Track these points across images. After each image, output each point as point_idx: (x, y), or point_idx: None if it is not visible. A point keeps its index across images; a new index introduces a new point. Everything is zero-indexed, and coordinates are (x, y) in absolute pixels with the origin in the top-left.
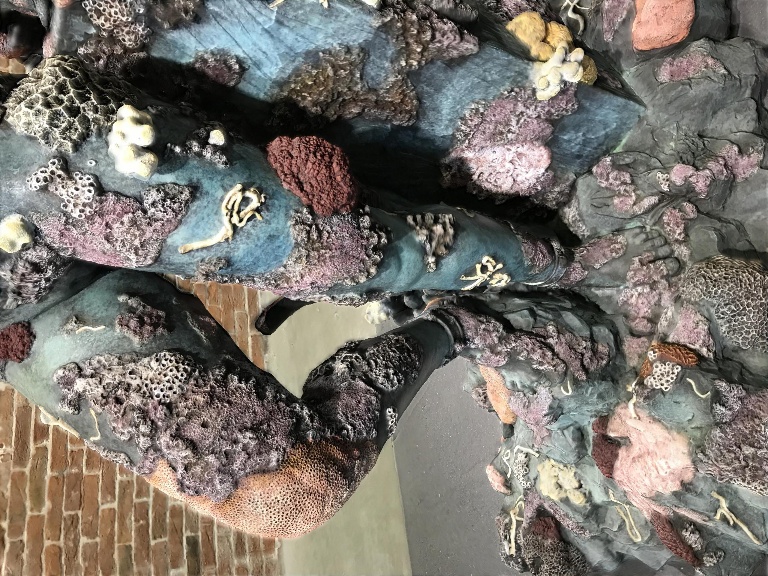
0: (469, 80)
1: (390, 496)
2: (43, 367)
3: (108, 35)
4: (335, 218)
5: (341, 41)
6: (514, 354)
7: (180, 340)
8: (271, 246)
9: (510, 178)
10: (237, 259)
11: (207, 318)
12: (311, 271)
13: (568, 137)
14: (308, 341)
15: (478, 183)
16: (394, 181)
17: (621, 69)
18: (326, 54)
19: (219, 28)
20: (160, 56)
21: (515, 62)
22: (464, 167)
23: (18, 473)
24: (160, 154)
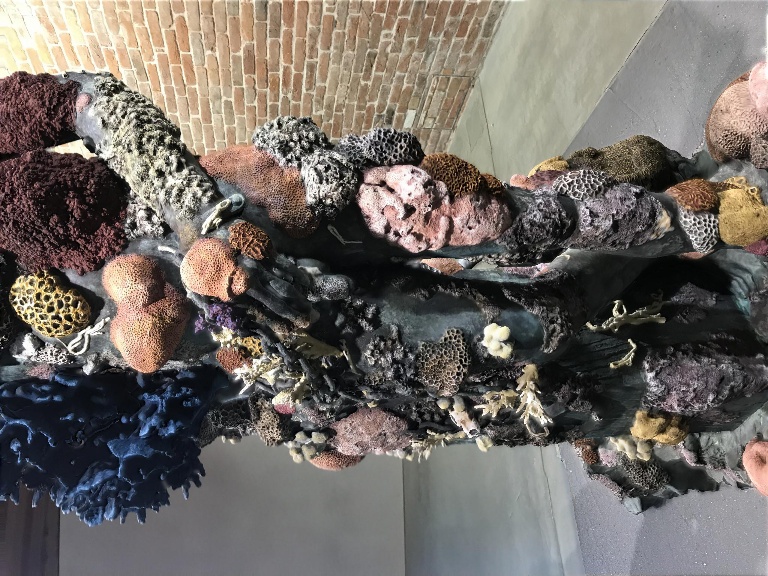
0: None
1: (613, 48)
2: None
3: None
4: None
5: None
6: None
7: None
8: None
9: None
10: None
11: None
12: None
13: None
14: None
15: None
16: None
17: (763, 409)
18: None
19: None
20: None
21: None
22: None
23: None
24: None
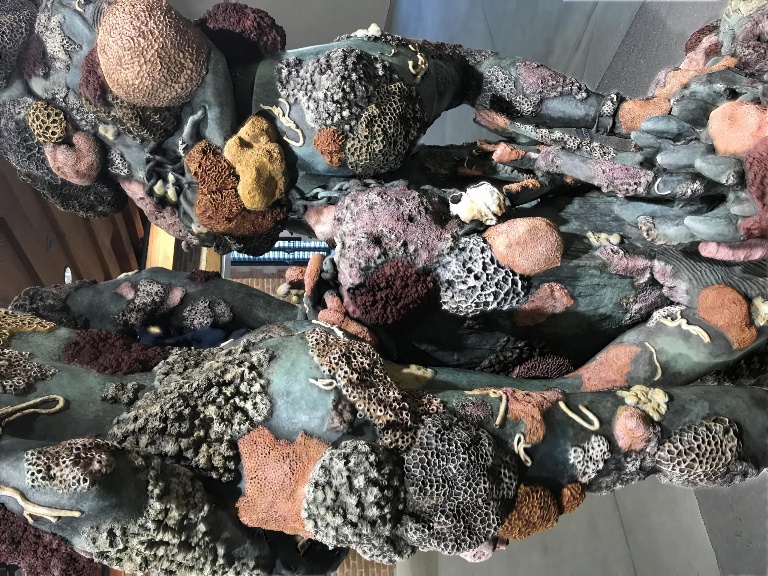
0: None
1: None
2: None
3: None
4: None
5: None
6: None
7: None
8: None
9: None
10: None
11: None
12: None
13: None
14: None
15: None
16: None
17: None
18: None
19: None
20: None
21: None
22: None
23: None
24: None
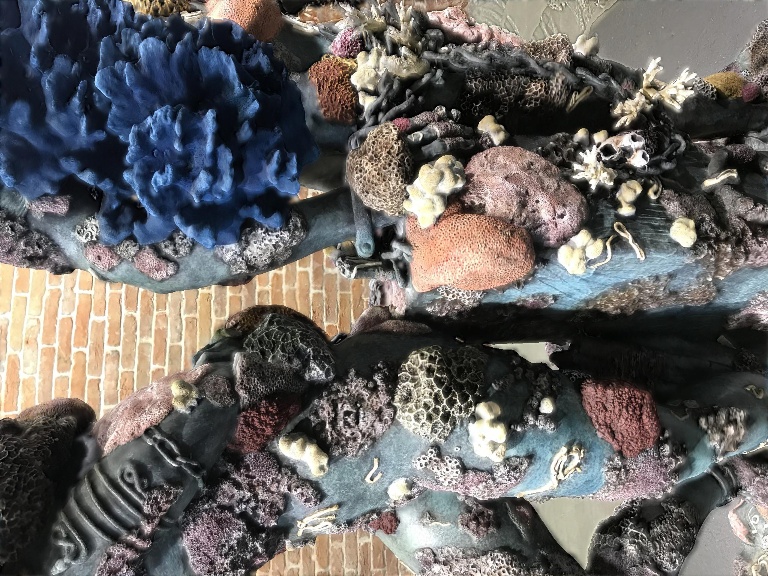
0: None
1: None
2: (406, 544)
3: None
4: (640, 456)
5: (651, 274)
6: None
7: (506, 538)
8: (586, 487)
9: None
10: (557, 495)
11: (522, 508)
12: (614, 494)
13: None
14: None
15: (765, 322)
16: (677, 328)
17: None
18: (635, 284)
19: (543, 285)
20: (489, 302)
21: None
22: (753, 318)
23: None
24: None
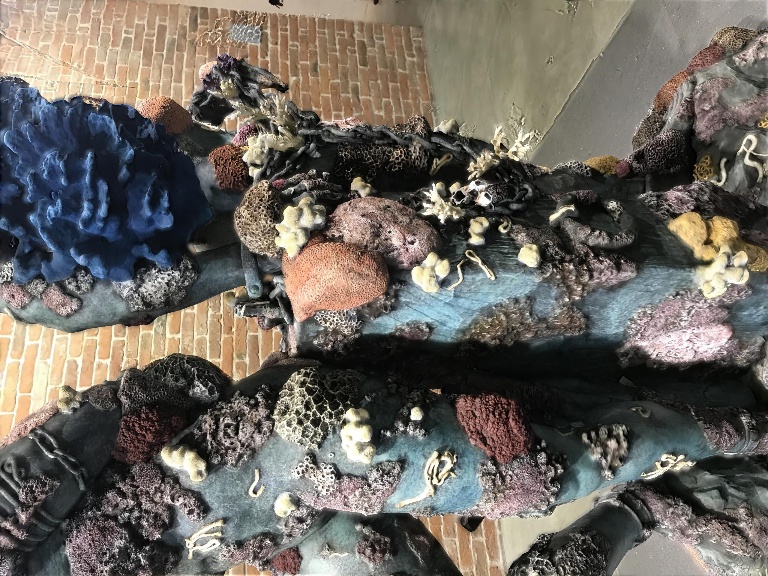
0: (632, 294)
1: None
2: None
3: (333, 329)
4: (515, 462)
5: (509, 296)
6: (706, 537)
7: (402, 564)
8: (465, 494)
9: (691, 351)
10: (439, 506)
11: (421, 537)
12: (499, 506)
13: (747, 312)
14: None
15: (658, 358)
16: (574, 369)
17: None
18: (498, 307)
19: (411, 310)
20: (370, 333)
21: (676, 273)
22: (640, 351)
23: None
24: (377, 439)
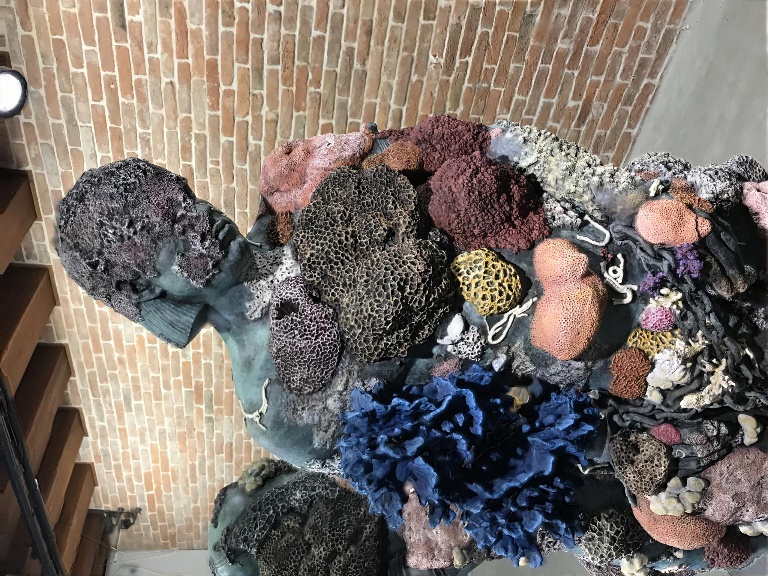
0: None
1: None
2: None
3: None
4: None
5: None
6: None
7: None
8: None
9: None
10: None
11: None
12: None
13: None
14: (743, 47)
15: None
16: None
17: None
18: None
19: None
20: None
21: None
22: None
23: (444, 79)
24: None
